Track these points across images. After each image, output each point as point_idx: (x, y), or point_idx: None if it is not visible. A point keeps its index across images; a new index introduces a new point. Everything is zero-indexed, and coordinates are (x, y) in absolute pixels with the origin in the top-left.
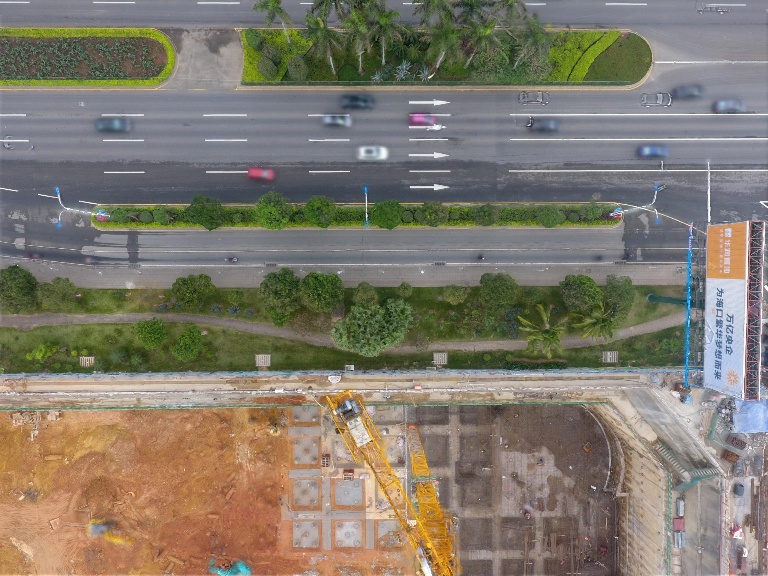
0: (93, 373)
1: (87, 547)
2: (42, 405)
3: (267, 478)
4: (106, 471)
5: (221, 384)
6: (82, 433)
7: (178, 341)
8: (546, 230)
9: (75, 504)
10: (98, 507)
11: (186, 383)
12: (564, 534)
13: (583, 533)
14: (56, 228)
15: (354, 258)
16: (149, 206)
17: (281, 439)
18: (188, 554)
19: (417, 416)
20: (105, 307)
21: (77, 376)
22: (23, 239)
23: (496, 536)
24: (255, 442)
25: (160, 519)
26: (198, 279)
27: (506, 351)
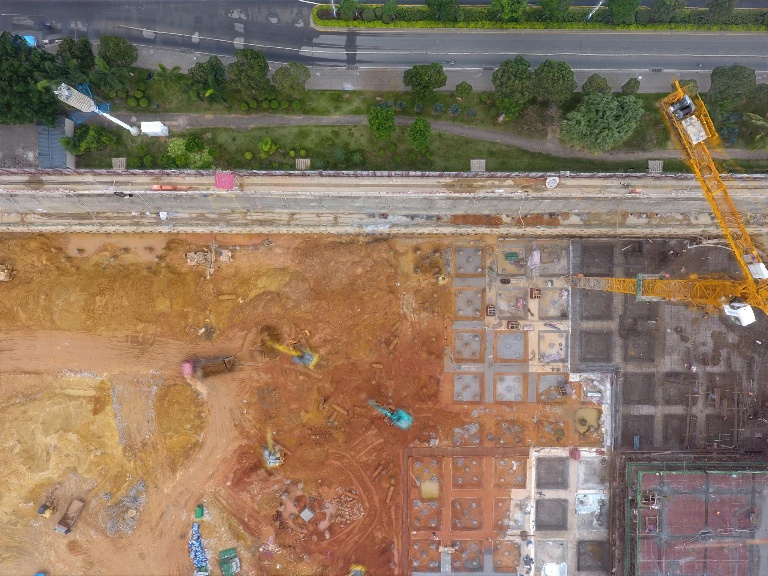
0: (310, 175)
1: (261, 386)
2: (240, 223)
3: (431, 329)
4: (284, 308)
5: (437, 188)
6: (254, 275)
7: (412, 128)
8: (765, 37)
9: (249, 343)
10: (272, 346)
11: (402, 186)
12: (728, 389)
13: (747, 389)
14: (275, 28)
15: (571, 63)
16: (370, 5)
17: (445, 290)
18: (351, 404)
19: (582, 269)
20: (322, 108)
21: (301, 171)
22: (242, 38)
23: (659, 391)
24: (420, 292)
25: (334, 359)
26: (434, 65)
27: (721, 160)
